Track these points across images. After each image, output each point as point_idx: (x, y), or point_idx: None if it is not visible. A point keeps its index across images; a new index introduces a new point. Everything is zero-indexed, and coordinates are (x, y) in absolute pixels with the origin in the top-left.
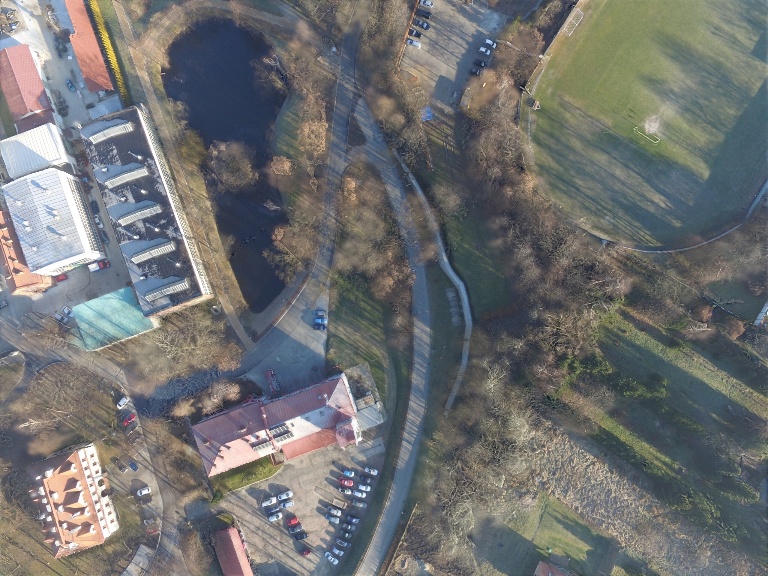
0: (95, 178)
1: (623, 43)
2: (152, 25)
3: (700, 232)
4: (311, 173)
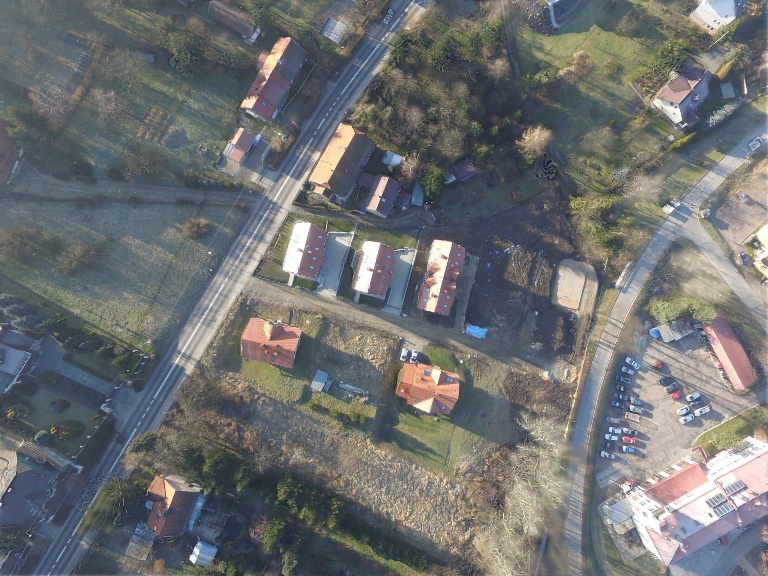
0: None
1: None
2: None
3: None
4: None
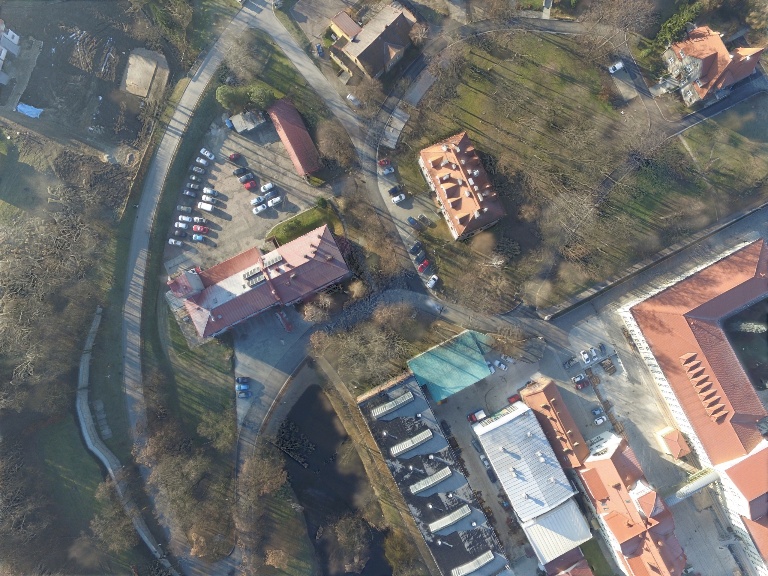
0: None
1: None
2: None
3: None
4: (245, 556)
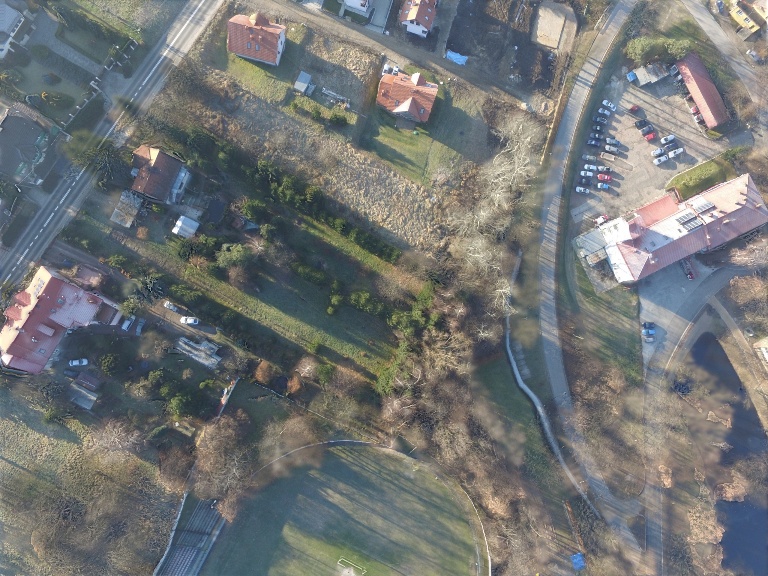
0: None
1: None
2: None
3: (289, 467)
4: (704, 488)
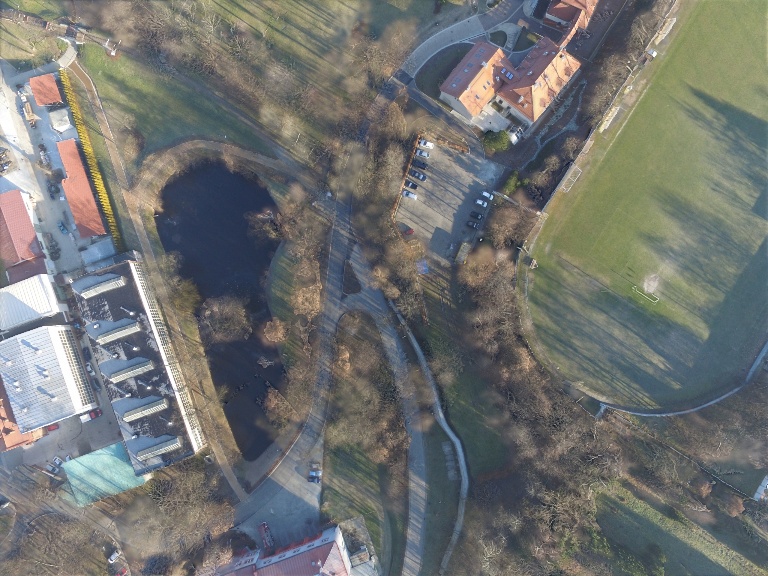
0: (87, 333)
1: (622, 200)
2: (145, 167)
3: (699, 394)
4: (305, 339)
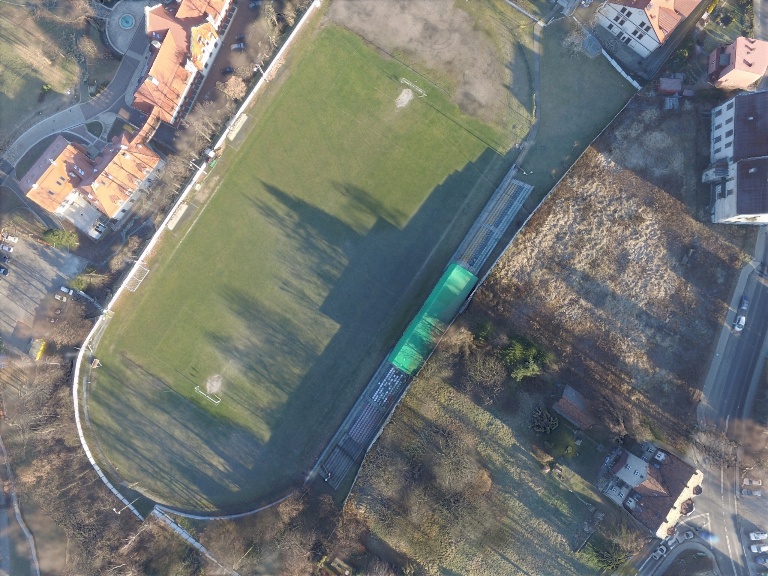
0: None
1: (189, 298)
2: None
3: (257, 497)
4: None
